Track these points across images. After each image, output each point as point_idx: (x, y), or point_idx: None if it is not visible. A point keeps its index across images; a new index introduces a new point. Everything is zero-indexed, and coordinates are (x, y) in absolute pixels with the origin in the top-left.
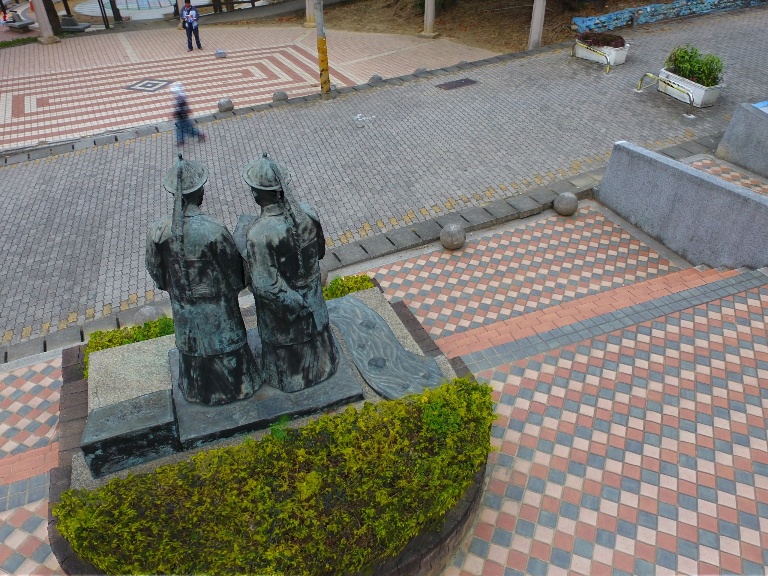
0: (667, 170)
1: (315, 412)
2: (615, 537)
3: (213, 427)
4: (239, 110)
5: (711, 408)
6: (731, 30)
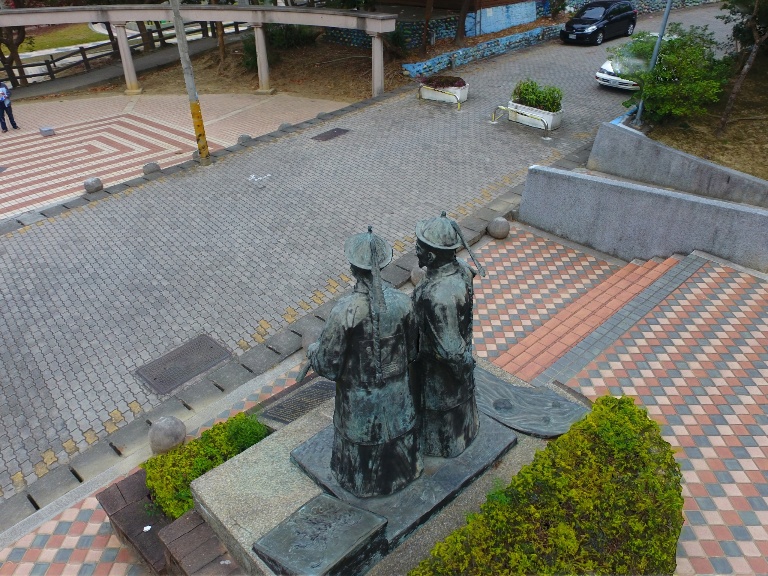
0: (587, 184)
1: (486, 469)
2: (763, 500)
3: (411, 516)
4: (112, 188)
5: (744, 372)
6: (531, 65)
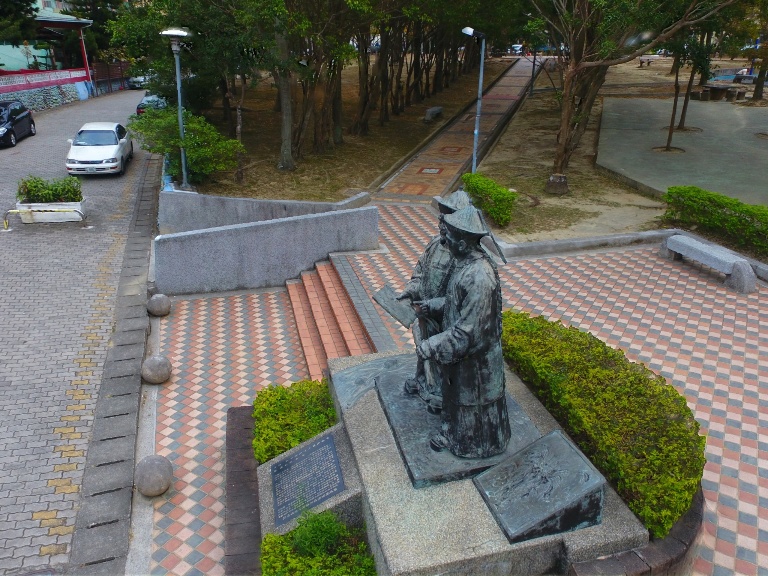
0: (223, 234)
1: None
2: None
3: (537, 434)
4: None
5: None
6: None
